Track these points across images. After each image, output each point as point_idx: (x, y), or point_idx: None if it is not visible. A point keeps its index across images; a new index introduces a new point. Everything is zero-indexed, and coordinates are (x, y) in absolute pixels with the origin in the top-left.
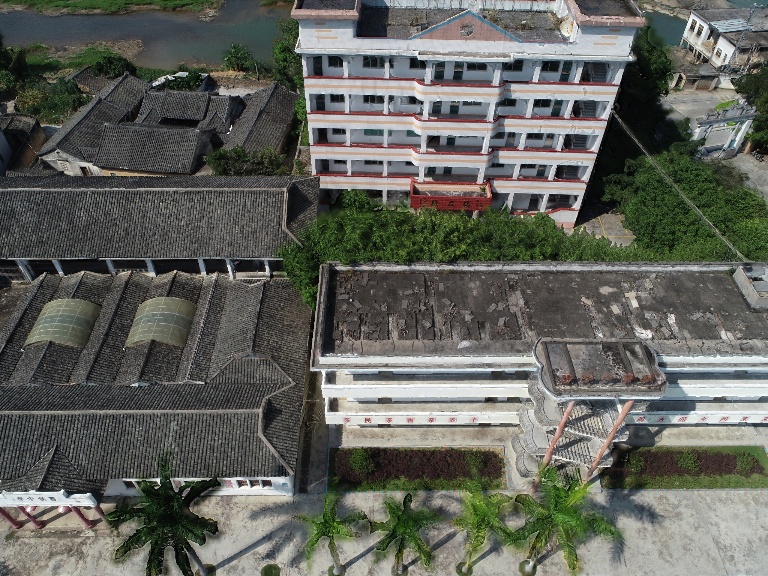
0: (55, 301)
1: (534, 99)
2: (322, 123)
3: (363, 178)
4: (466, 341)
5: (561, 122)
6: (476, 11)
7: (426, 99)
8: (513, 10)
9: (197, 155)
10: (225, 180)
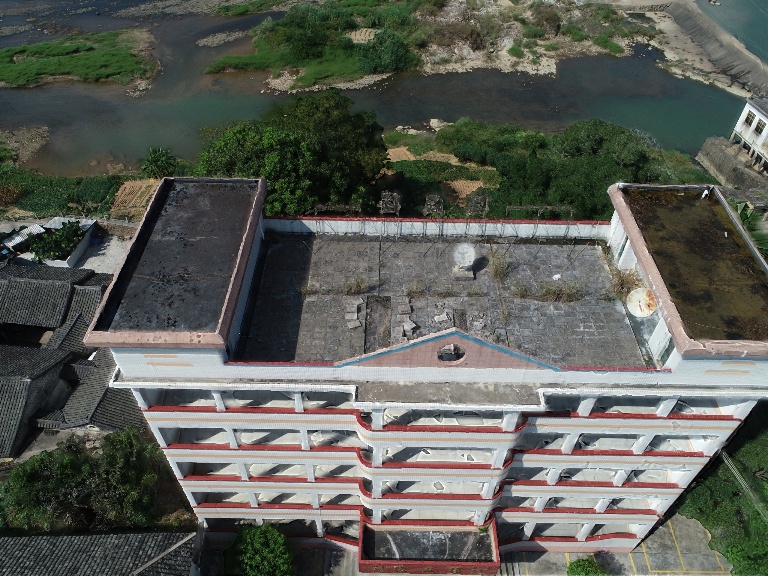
0: None
1: (579, 434)
2: (192, 457)
3: (279, 509)
4: None
5: (625, 457)
6: (469, 263)
7: (376, 445)
8: (534, 237)
9: (28, 417)
10: (14, 567)
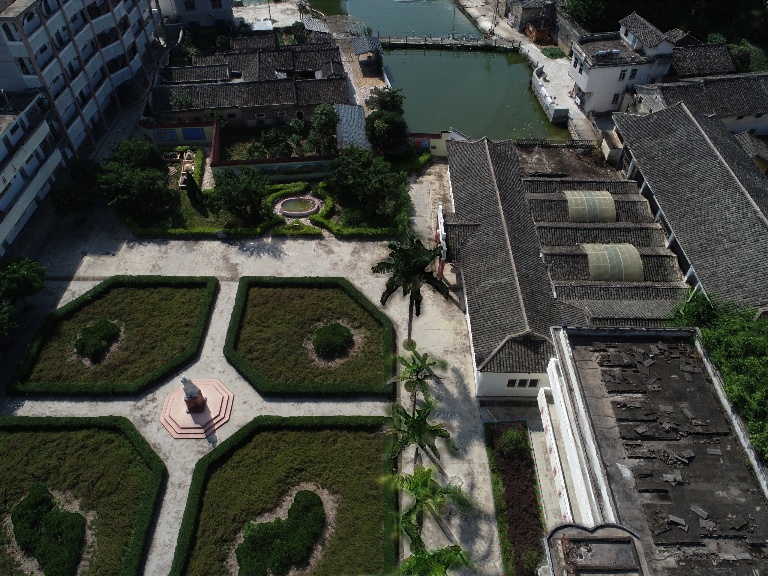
0: (608, 192)
1: None
2: None
3: None
4: (631, 474)
5: None
6: None
7: None
8: None
9: None
10: None
